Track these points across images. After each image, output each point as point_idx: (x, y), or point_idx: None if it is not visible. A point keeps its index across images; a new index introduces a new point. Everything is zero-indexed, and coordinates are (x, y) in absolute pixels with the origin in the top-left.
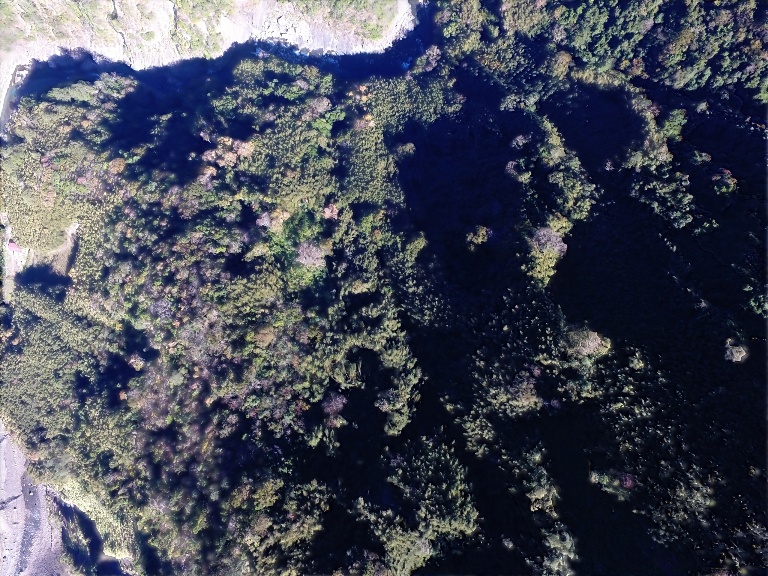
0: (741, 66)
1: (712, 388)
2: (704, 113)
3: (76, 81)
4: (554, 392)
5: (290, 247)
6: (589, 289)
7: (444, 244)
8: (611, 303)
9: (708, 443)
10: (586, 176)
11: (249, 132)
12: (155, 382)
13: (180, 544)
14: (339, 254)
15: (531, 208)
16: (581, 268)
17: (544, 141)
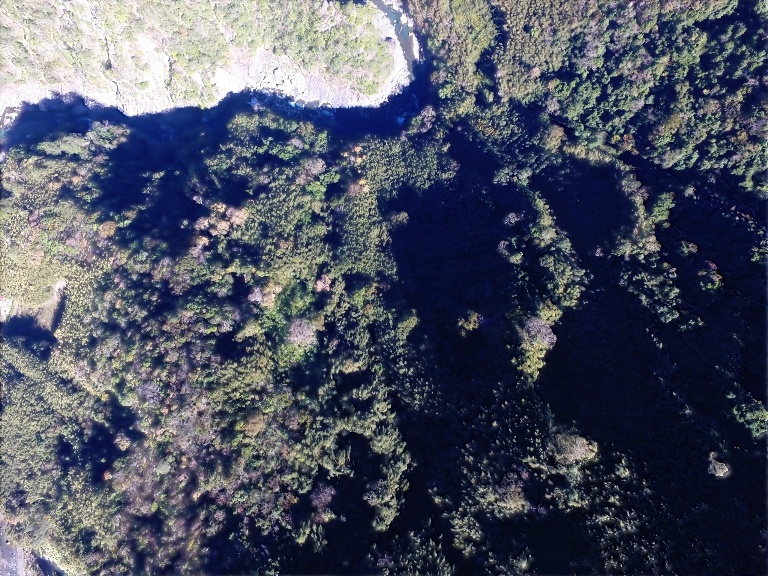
0: (727, 153)
1: (695, 503)
2: (691, 197)
3: (67, 129)
4: (541, 496)
5: (281, 320)
6: (577, 382)
7: (435, 323)
8: (598, 399)
9: (690, 562)
10: (576, 259)
11: (242, 193)
12: (141, 464)
13: None
14: (330, 326)
15: (522, 293)
16: (570, 358)
17: (536, 222)
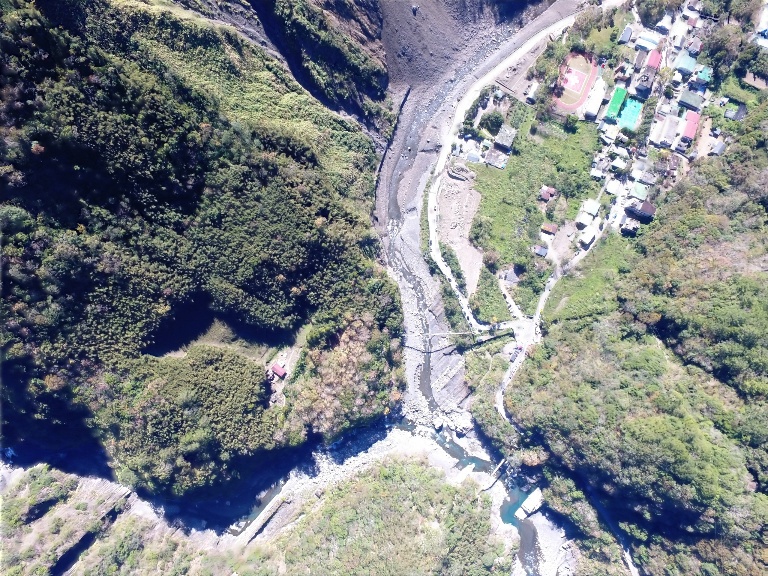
0: None
1: None
2: None
3: None
4: None
5: None
6: None
7: None
8: None
9: None
10: None
11: None
12: None
13: None
14: None
15: None
16: None
17: None
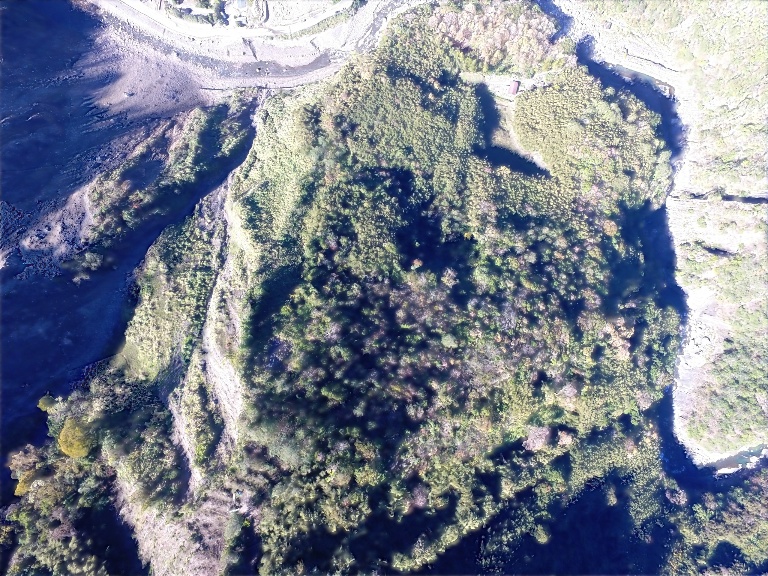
0: None
1: None
2: None
3: None
4: None
5: None
6: None
7: (541, 561)
8: None
9: None
10: None
11: None
12: (433, 300)
13: (303, 365)
14: None
15: None
16: None
17: None
